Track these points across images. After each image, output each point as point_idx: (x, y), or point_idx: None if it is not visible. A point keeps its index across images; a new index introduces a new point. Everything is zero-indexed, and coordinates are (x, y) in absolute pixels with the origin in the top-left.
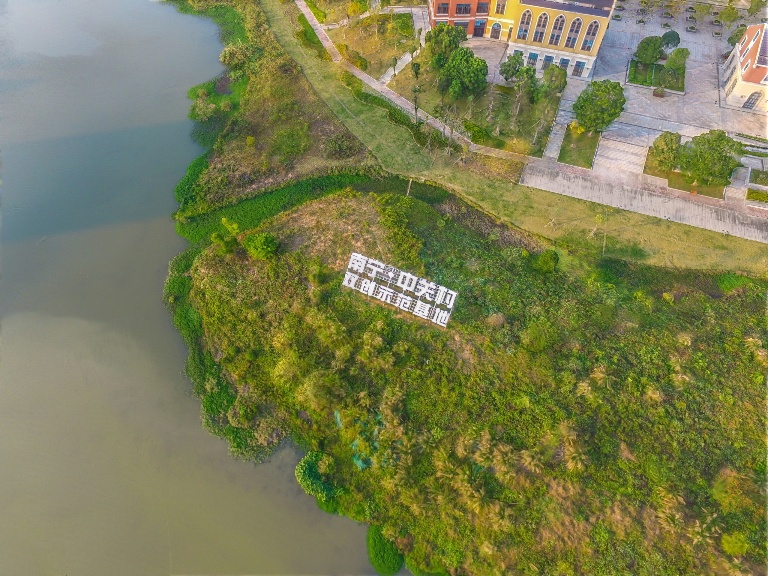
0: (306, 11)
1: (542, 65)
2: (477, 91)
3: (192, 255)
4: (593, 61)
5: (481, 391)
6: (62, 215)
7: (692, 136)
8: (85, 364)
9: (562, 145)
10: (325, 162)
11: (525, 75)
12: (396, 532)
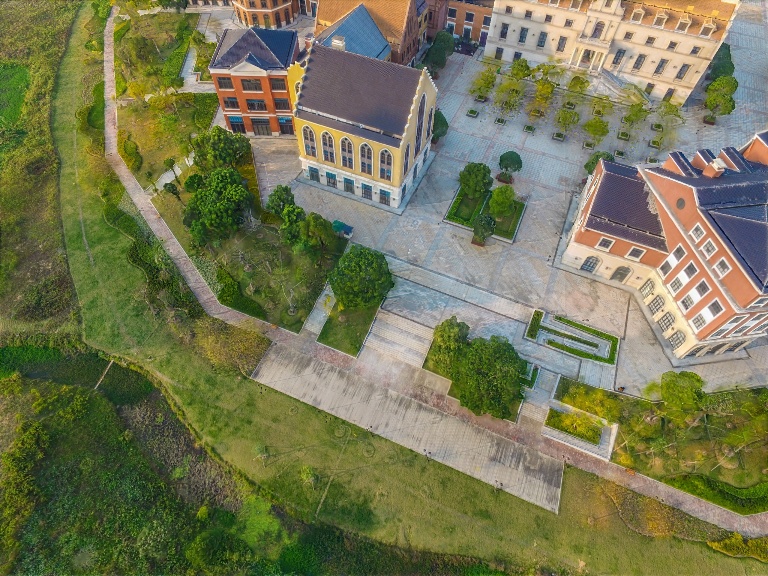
0: (110, 78)
1: (344, 187)
2: (230, 232)
3: None
4: (398, 192)
5: None
6: None
7: (501, 313)
8: None
9: (330, 315)
10: (9, 325)
11: (286, 219)
12: None
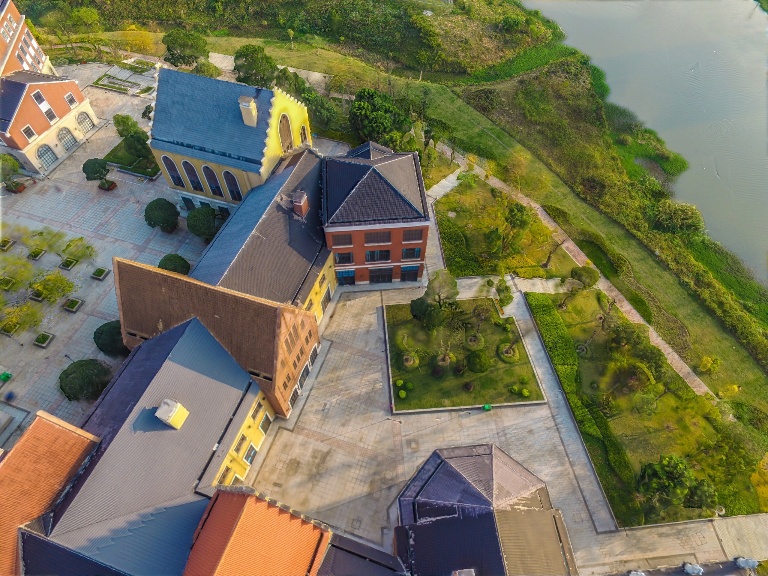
0: None
1: None
2: None
3: (556, 38)
4: None
5: None
6: (672, 64)
7: None
8: (572, 1)
9: None
10: (495, 87)
11: None
12: None
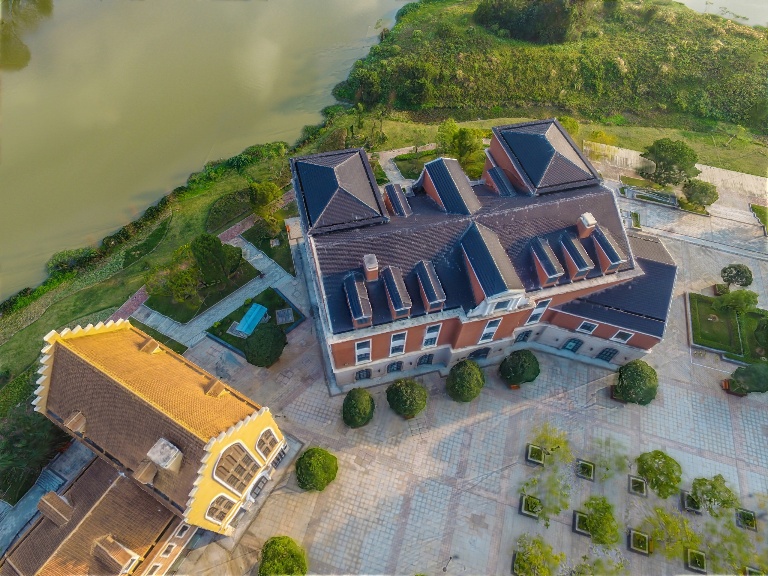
0: None
1: None
2: None
3: None
4: None
5: (767, 49)
6: None
7: (664, 231)
8: None
9: None
10: None
11: None
12: (764, 30)
